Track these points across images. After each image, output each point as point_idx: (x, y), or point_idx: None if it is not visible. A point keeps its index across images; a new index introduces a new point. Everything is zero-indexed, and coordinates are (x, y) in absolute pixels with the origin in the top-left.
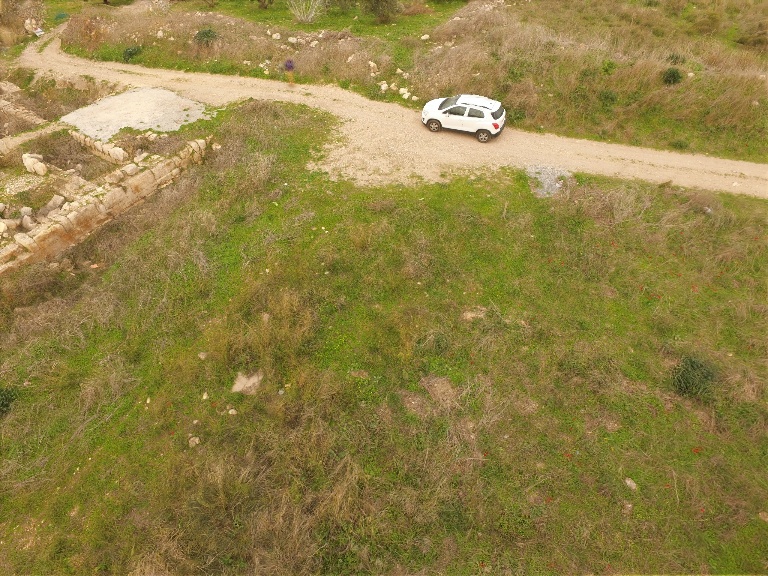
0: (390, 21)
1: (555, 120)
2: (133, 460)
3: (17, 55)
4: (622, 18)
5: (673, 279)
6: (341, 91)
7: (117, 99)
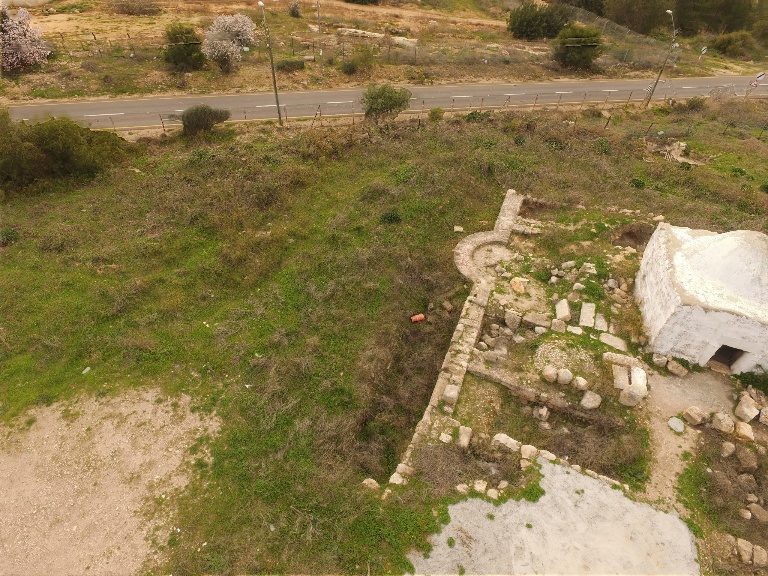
0: None
1: None
2: (311, 210)
3: None
4: None
5: None
6: None
7: None
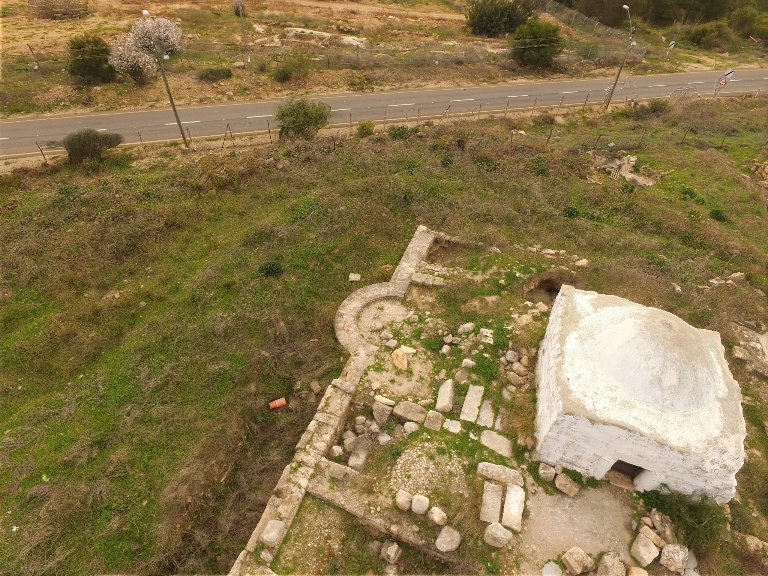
0: None
1: None
2: None
3: None
4: None
5: None
6: None
7: None
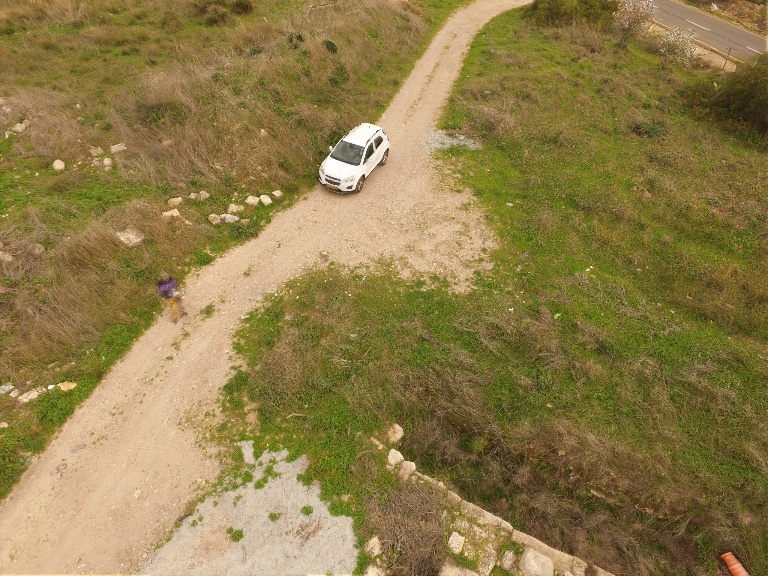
0: None
1: (357, 117)
2: None
3: None
4: (110, 44)
5: (563, 119)
6: (216, 266)
7: None
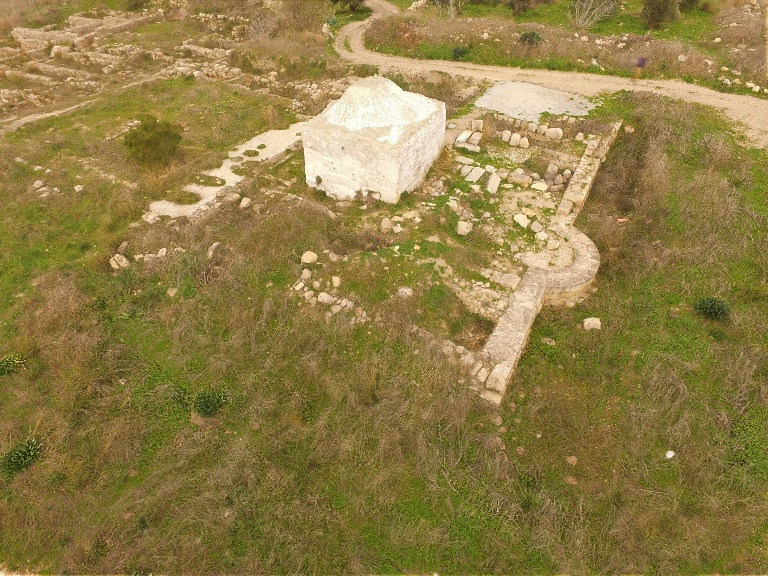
0: (660, 27)
1: None
2: None
3: (337, 54)
4: None
5: None
6: (688, 85)
7: (500, 90)
